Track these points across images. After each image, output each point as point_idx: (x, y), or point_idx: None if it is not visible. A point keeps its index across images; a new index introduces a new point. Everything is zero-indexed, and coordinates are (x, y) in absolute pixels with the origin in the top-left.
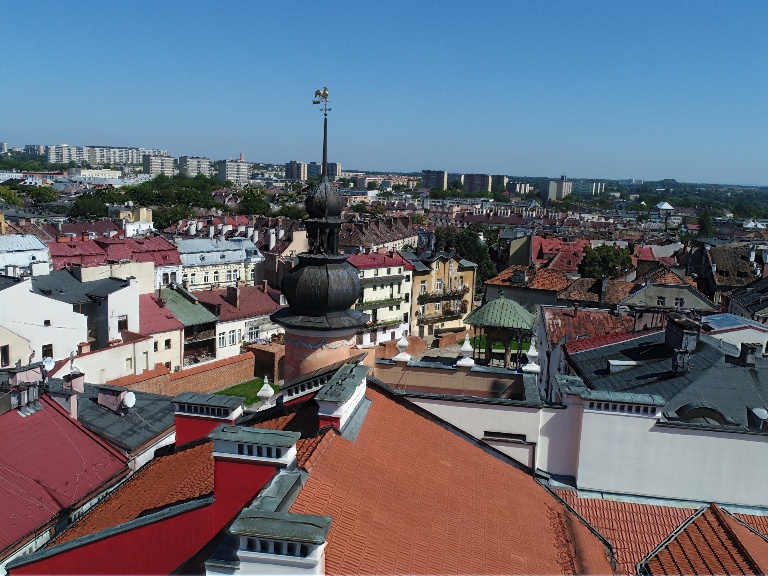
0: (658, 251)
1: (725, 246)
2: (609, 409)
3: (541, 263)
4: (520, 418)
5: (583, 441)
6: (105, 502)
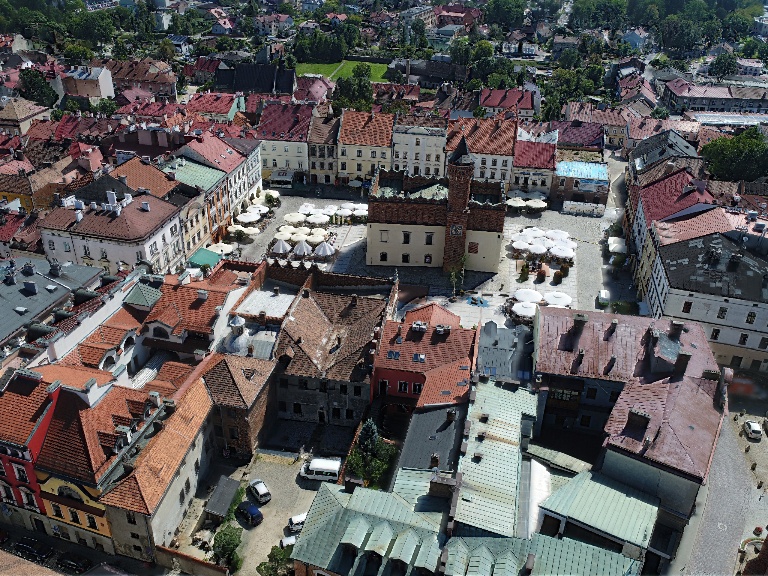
0: None
1: None
2: (57, 340)
3: None
4: None
5: None
6: (2, 437)
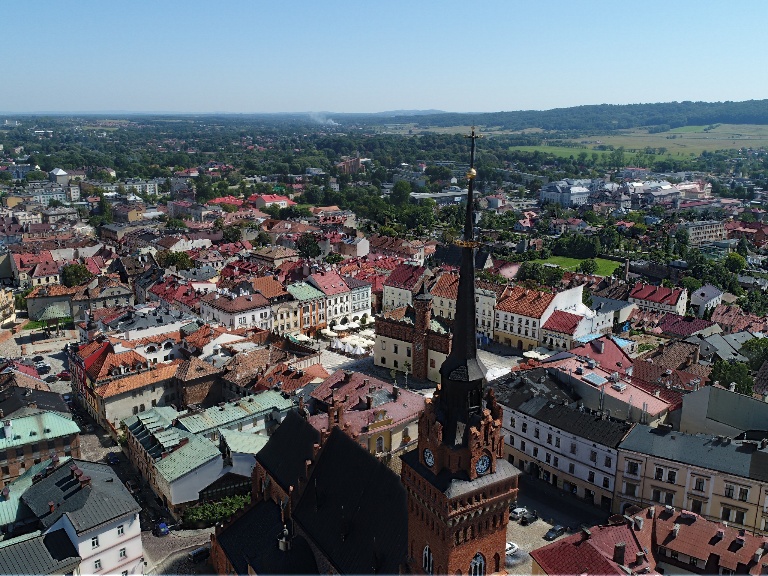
0: (90, 250)
1: (122, 231)
2: (132, 330)
3: (24, 270)
4: (122, 334)
5: (130, 335)
6: None
